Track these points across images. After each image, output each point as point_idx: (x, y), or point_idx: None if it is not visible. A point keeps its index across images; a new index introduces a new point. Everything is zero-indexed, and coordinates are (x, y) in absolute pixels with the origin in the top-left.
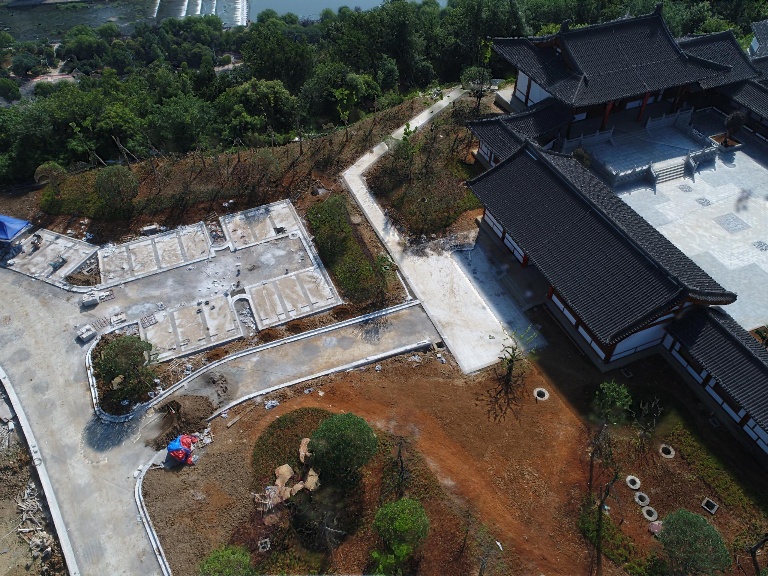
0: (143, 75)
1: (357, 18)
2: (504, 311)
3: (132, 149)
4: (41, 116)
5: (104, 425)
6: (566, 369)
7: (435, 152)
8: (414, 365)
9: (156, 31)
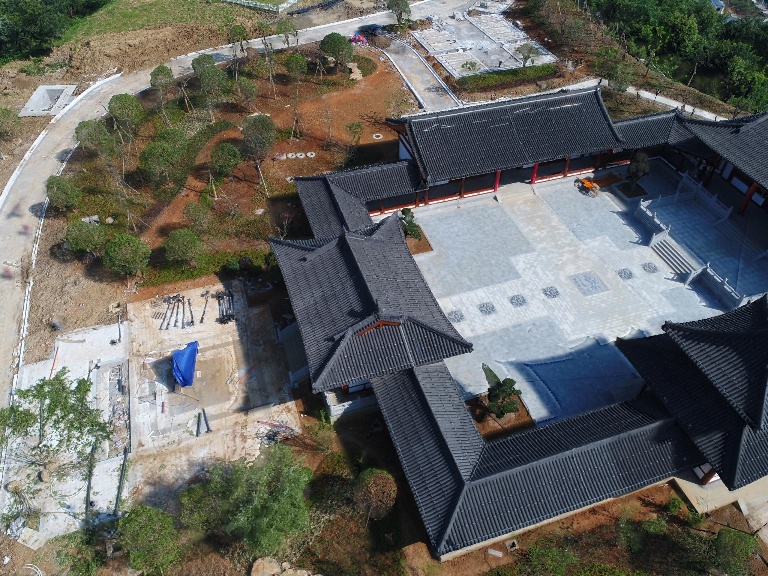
0: None
1: None
2: None
3: None
4: None
5: None
6: None
7: None
8: None
9: None
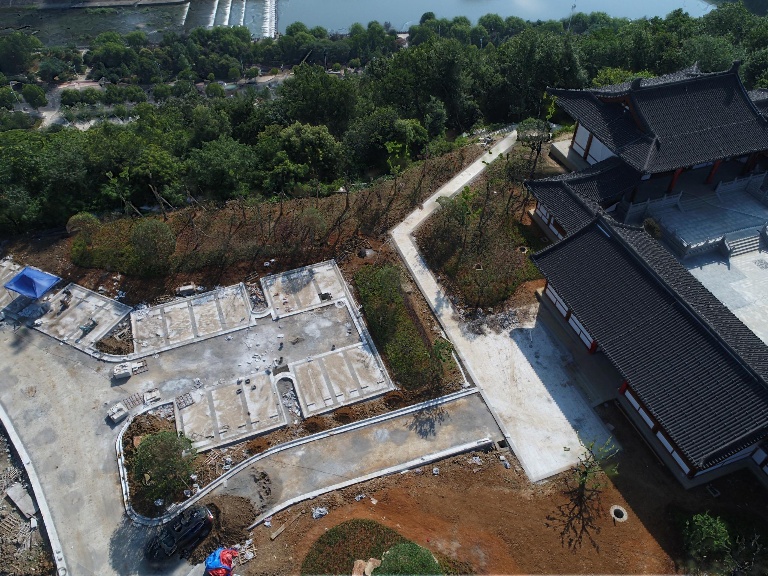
0: (178, 105)
1: (403, 55)
2: (572, 406)
3: (169, 196)
4: (75, 159)
5: (135, 528)
6: (645, 482)
7: (489, 211)
8: (475, 470)
9: (184, 41)
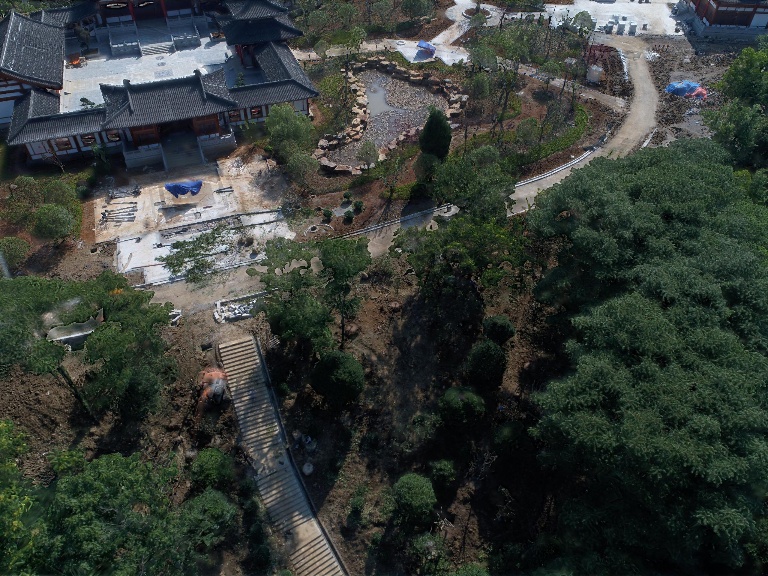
0: None
1: None
2: None
3: None
4: None
5: None
6: None
7: None
8: None
9: None
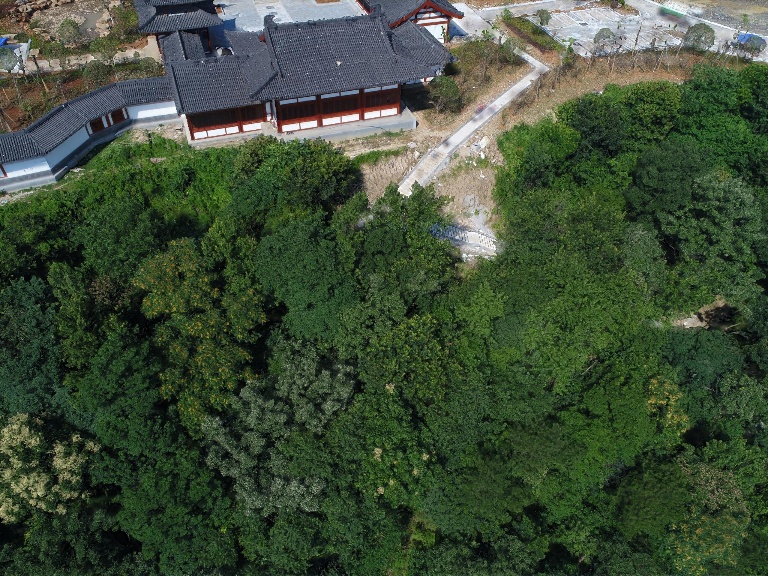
0: None
1: None
2: None
3: None
4: None
5: None
6: None
7: None
8: None
9: None
